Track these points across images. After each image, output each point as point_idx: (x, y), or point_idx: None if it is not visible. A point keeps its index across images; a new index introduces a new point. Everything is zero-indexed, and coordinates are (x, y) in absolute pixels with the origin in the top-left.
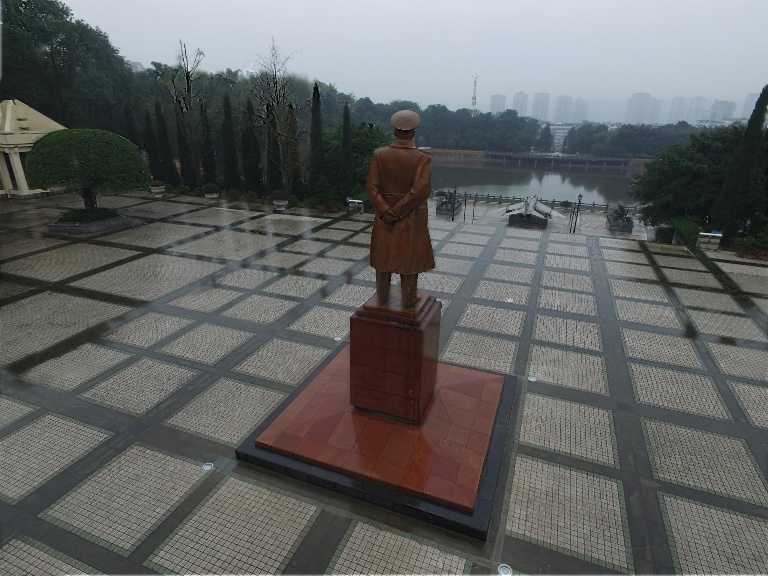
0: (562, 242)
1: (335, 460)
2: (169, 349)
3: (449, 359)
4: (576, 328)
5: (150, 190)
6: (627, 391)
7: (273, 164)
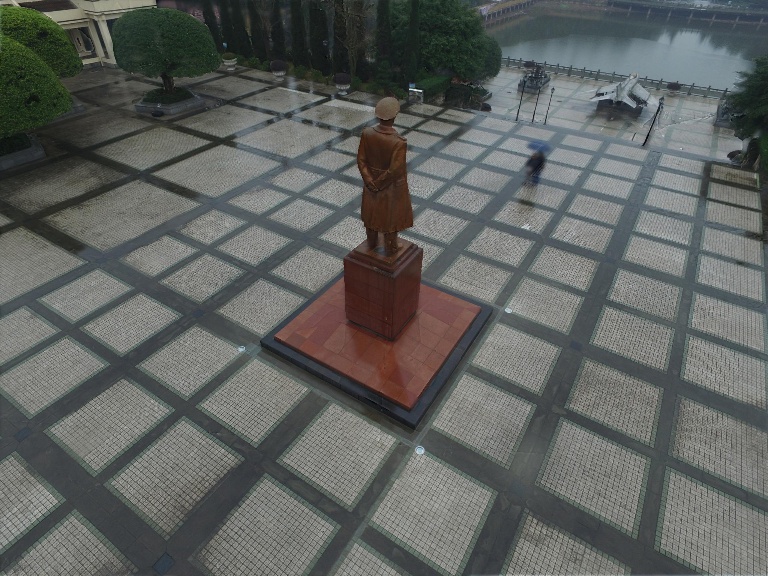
0: (617, 158)
1: (326, 359)
2: (225, 248)
3: (445, 283)
4: (575, 264)
5: None
6: (587, 332)
7: None
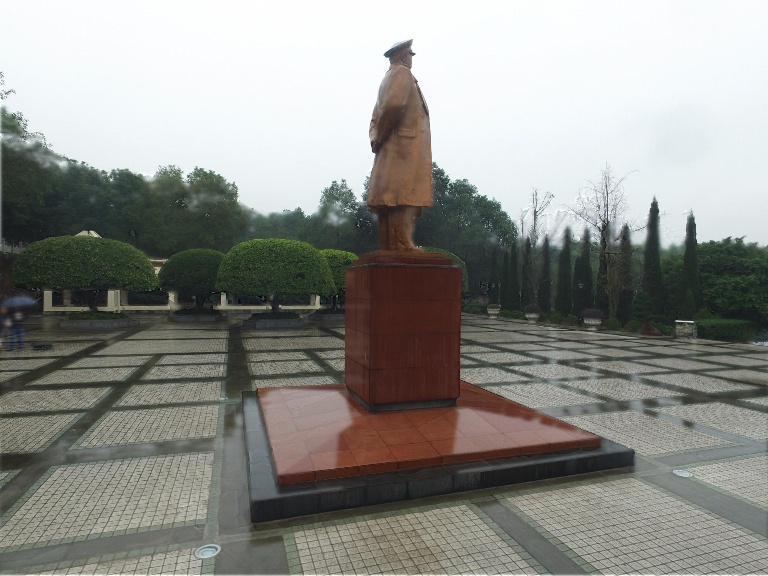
0: None
1: (269, 409)
2: None
3: (566, 421)
4: None
5: None
6: None
7: (602, 288)
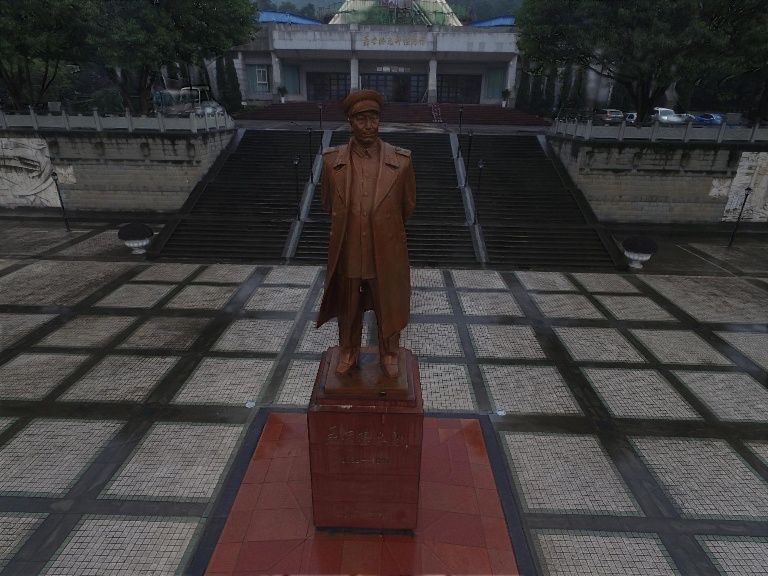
0: None
1: None
2: None
3: None
4: None
5: None
6: None
7: None
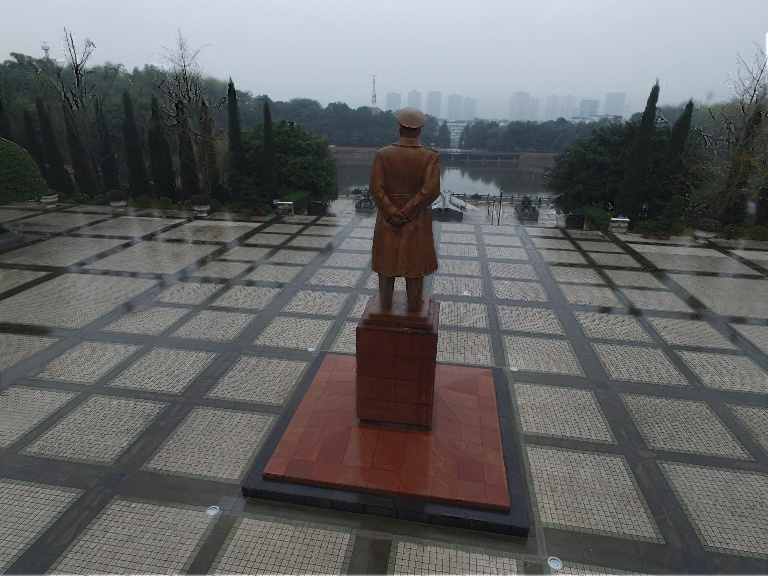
0: (495, 234)
1: (357, 480)
2: (121, 382)
3: None
4: (536, 315)
5: (38, 200)
6: (599, 370)
7: (187, 166)
